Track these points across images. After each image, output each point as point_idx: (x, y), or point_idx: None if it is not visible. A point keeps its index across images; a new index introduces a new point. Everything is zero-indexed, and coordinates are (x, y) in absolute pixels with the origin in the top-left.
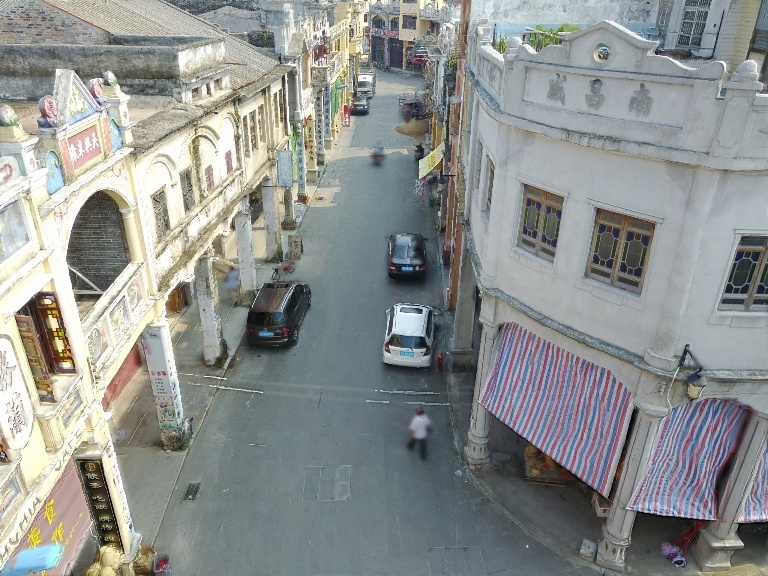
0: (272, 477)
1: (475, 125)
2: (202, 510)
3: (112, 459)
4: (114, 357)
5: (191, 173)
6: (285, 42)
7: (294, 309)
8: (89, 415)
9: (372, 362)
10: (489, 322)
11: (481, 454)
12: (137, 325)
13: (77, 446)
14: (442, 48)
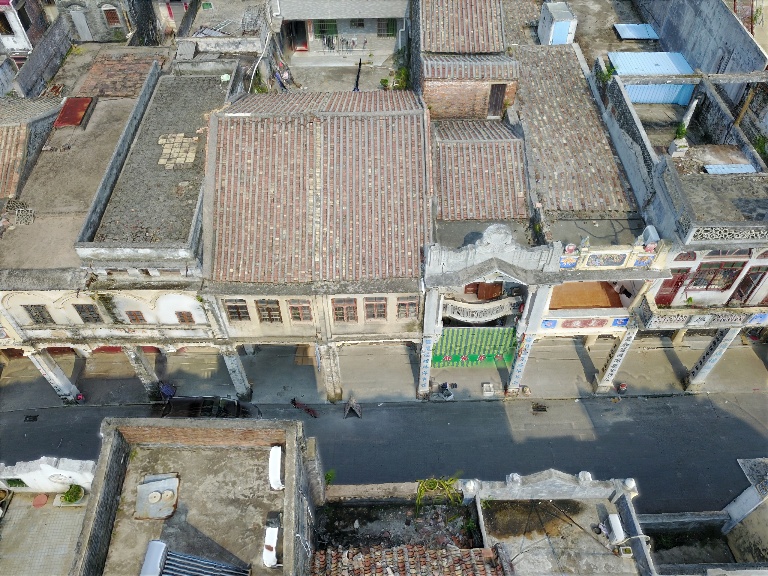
0: (27, 457)
1: None
2: (14, 427)
3: None
4: None
5: (97, 308)
6: (433, 264)
7: None
8: None
9: None
10: None
11: None
12: None
13: None
14: None
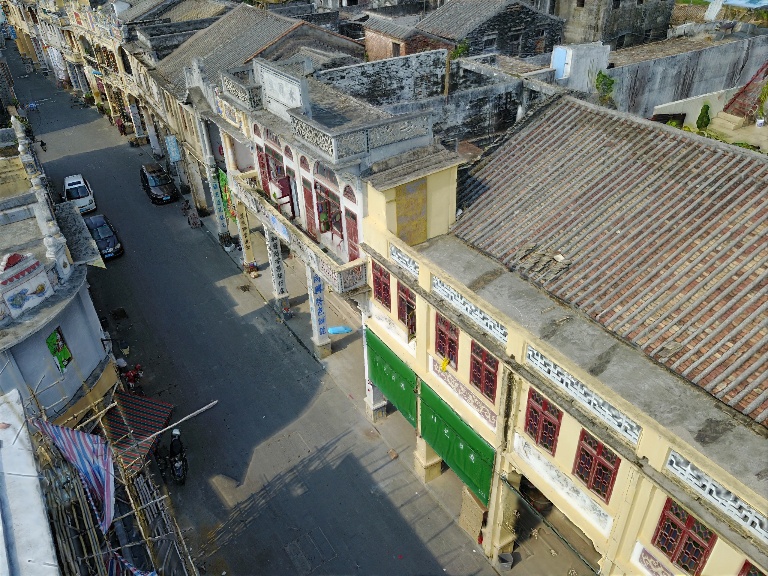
0: None
1: None
2: (133, 153)
3: None
4: None
5: None
6: (187, 82)
7: None
8: None
9: (98, 193)
10: None
11: None
12: None
13: None
14: None
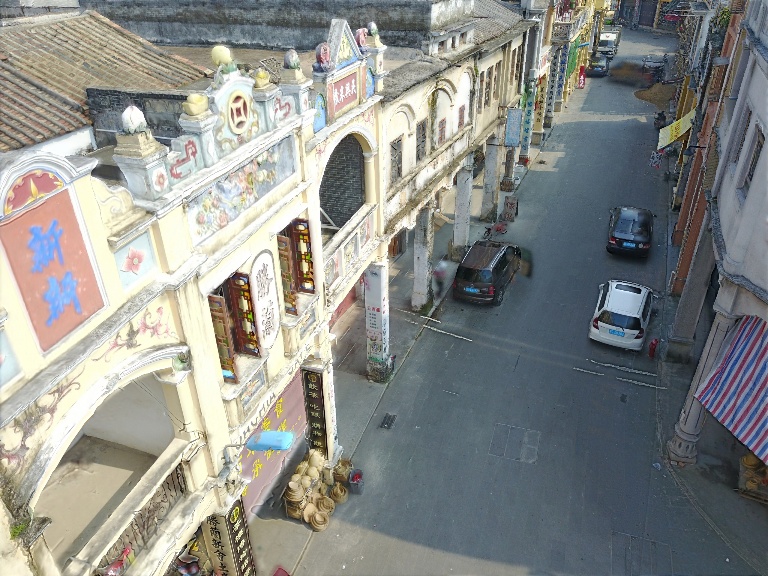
0: (462, 425)
1: (745, 90)
2: (395, 440)
3: (330, 375)
4: (343, 286)
5: (427, 125)
6: None
7: (503, 270)
8: (319, 333)
9: (576, 335)
10: (725, 312)
11: (687, 452)
12: (364, 261)
13: (306, 357)
14: (710, 2)
